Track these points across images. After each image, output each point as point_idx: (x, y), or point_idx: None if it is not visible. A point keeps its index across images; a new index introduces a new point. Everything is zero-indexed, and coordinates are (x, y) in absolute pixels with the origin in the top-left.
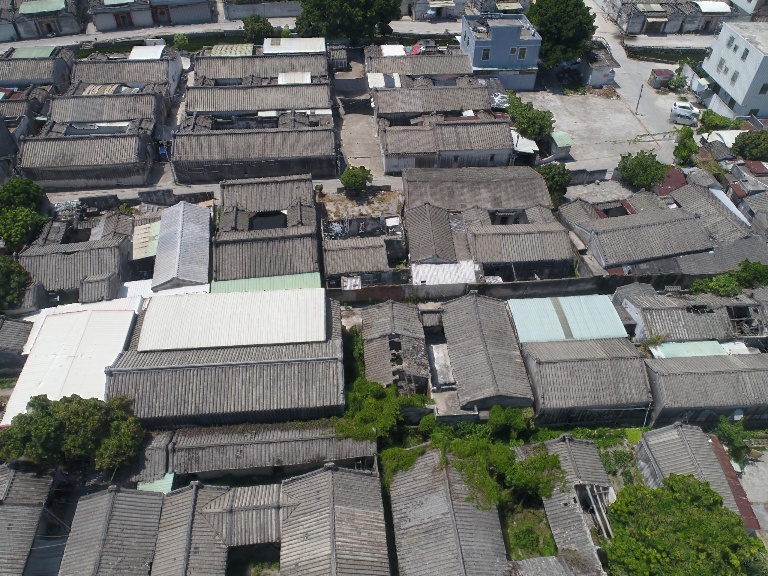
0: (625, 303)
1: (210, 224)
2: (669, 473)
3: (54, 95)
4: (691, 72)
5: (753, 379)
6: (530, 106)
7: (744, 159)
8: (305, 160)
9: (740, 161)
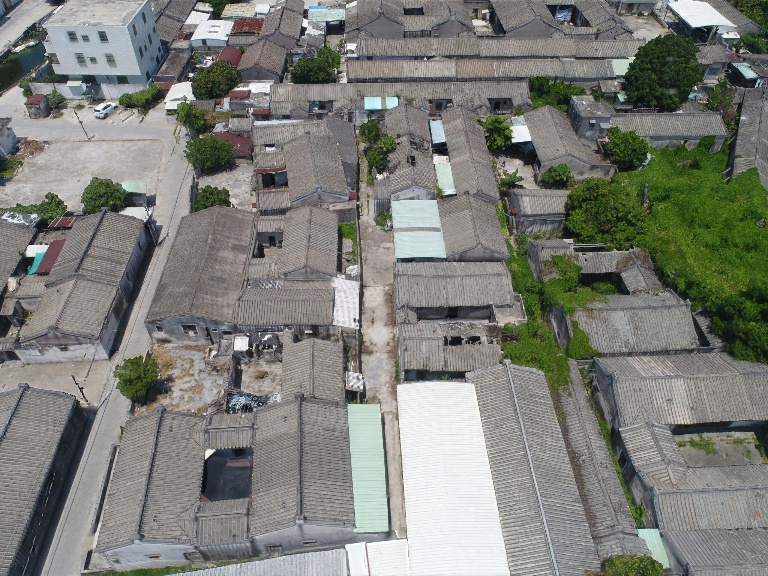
0: (395, 197)
1: (199, 571)
2: (552, 210)
3: None
4: (47, 85)
5: (476, 156)
6: (56, 196)
7: (219, 98)
8: (62, 442)
9: (225, 99)
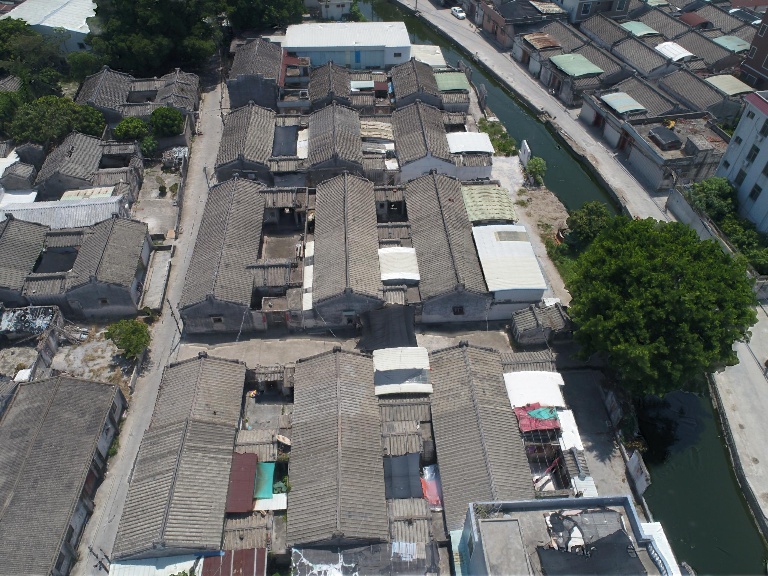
0: None
1: None
2: None
3: (336, 103)
4: None
5: None
6: None
7: None
8: None
9: None
